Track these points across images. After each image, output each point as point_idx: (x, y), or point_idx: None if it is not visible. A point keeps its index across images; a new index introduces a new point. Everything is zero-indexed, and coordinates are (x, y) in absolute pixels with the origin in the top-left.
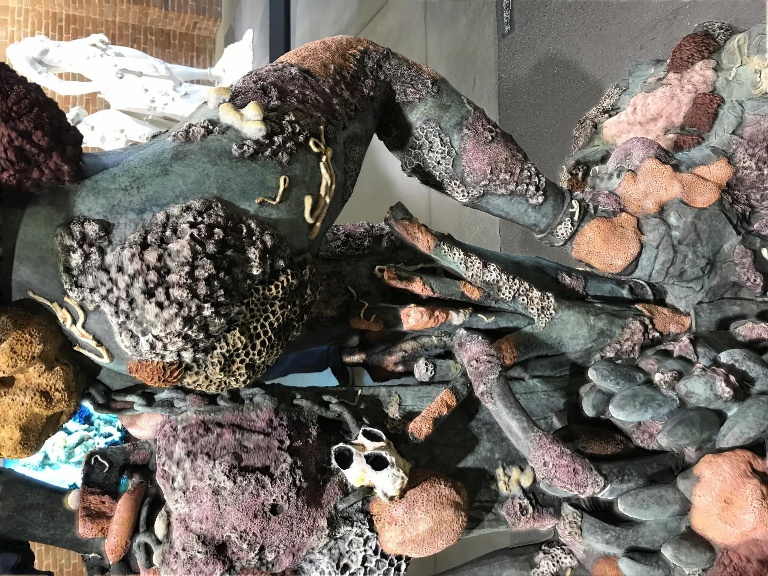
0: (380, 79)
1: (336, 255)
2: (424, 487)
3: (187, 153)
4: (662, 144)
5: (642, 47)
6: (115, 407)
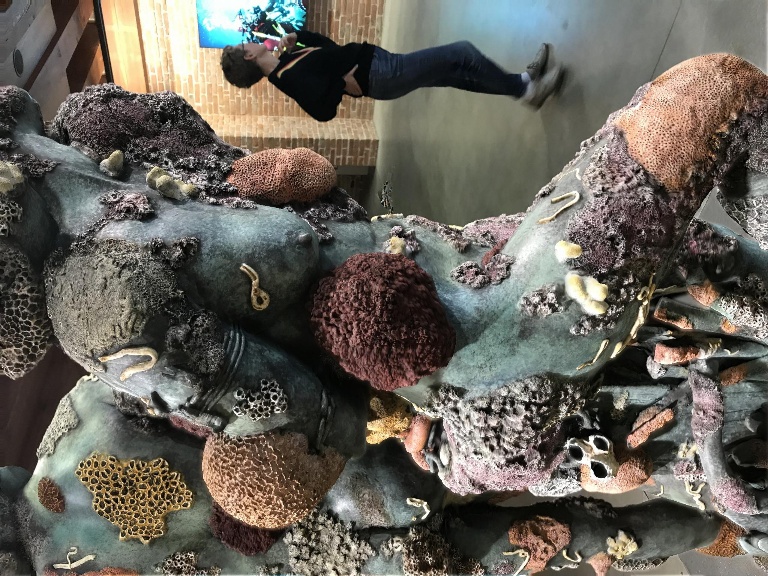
0: (738, 153)
1: None
2: (624, 467)
3: (532, 331)
4: None
5: None
6: None
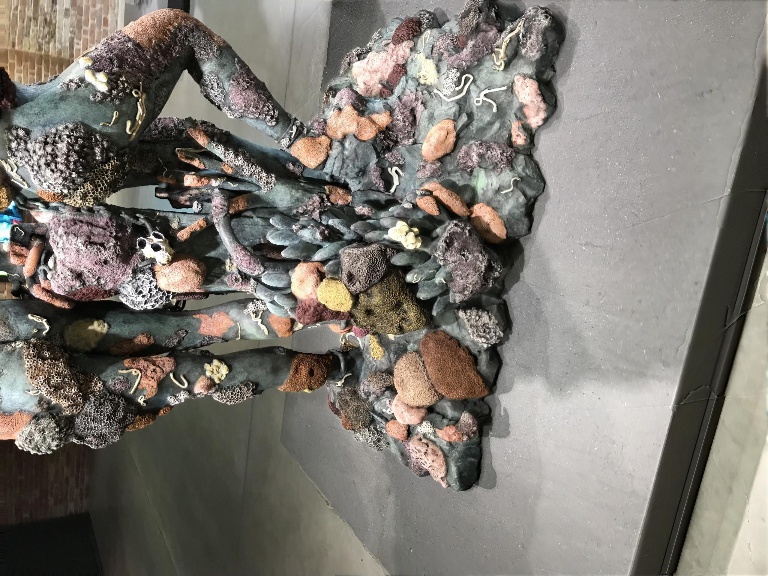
0: (185, 44)
1: (154, 139)
2: (182, 262)
3: (67, 97)
4: (375, 89)
5: (407, 3)
6: (29, 206)
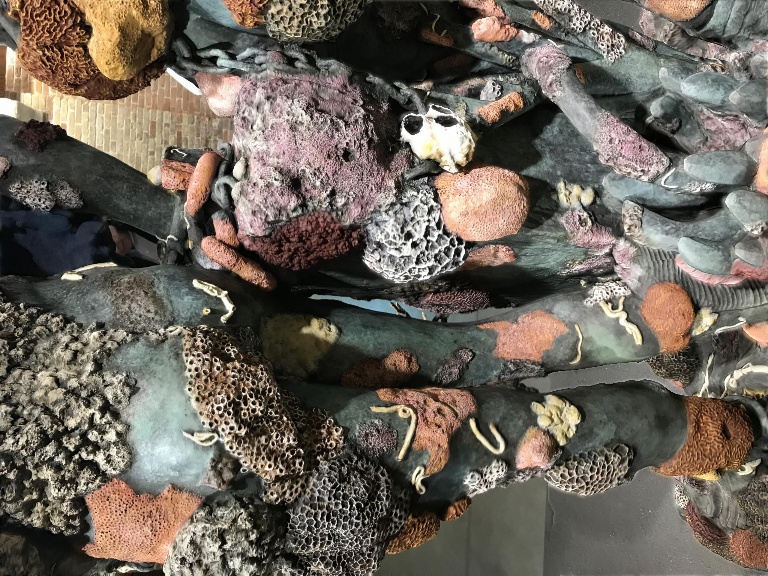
0: None
1: None
2: (489, 169)
3: None
4: None
5: None
6: (199, 63)
